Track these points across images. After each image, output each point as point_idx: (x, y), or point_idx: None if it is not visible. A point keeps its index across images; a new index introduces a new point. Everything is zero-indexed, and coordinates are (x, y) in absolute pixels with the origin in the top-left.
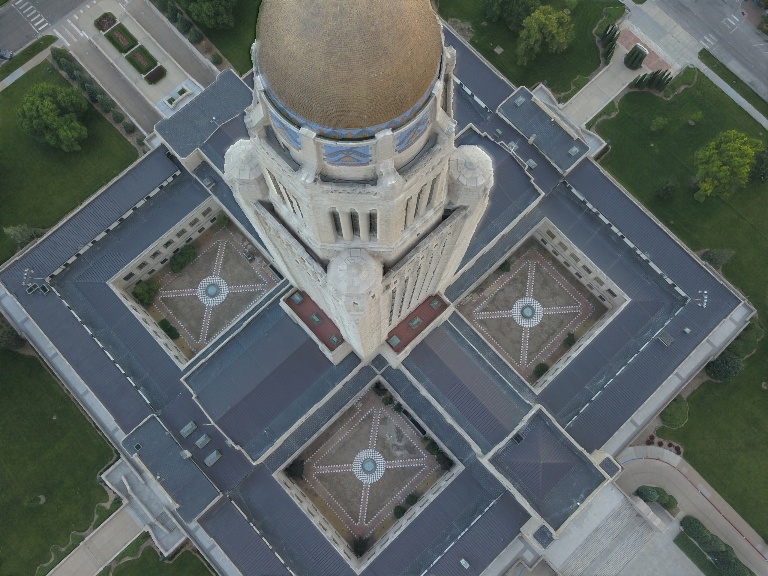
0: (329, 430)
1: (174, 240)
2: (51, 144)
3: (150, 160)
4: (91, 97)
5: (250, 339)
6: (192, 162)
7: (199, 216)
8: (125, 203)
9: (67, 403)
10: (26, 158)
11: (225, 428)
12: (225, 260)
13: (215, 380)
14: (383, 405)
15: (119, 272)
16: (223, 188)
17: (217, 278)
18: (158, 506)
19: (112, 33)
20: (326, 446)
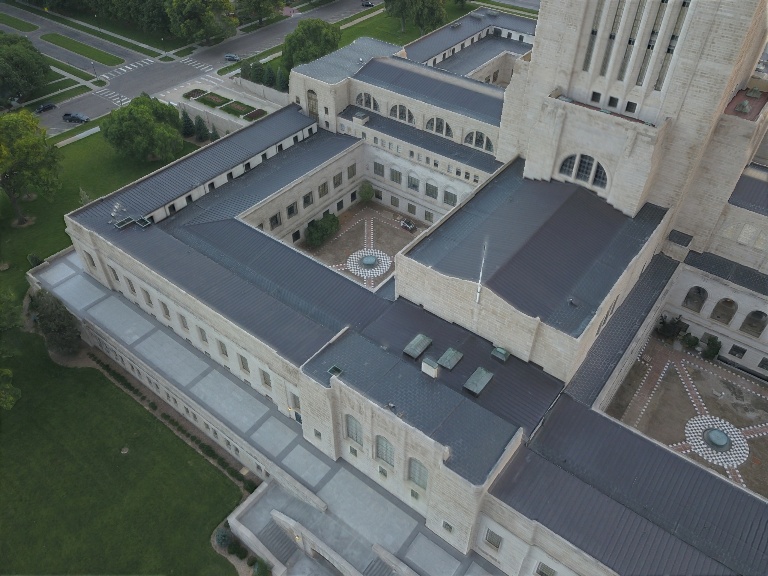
0: (618, 399)
1: (314, 197)
2: (140, 150)
3: (281, 115)
4: (184, 129)
5: (487, 208)
6: (340, 97)
7: (344, 171)
8: (254, 147)
9: (149, 425)
10: (99, 183)
11: (502, 295)
12: (377, 234)
13: (454, 251)
14: (682, 356)
15: (252, 207)
16: (380, 122)
17: (371, 250)
18: (360, 549)
19: (204, 96)
20: (626, 422)
